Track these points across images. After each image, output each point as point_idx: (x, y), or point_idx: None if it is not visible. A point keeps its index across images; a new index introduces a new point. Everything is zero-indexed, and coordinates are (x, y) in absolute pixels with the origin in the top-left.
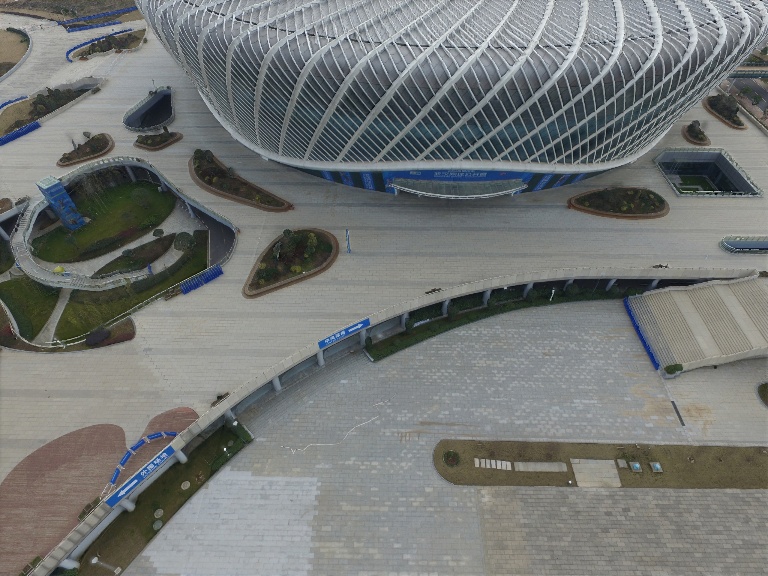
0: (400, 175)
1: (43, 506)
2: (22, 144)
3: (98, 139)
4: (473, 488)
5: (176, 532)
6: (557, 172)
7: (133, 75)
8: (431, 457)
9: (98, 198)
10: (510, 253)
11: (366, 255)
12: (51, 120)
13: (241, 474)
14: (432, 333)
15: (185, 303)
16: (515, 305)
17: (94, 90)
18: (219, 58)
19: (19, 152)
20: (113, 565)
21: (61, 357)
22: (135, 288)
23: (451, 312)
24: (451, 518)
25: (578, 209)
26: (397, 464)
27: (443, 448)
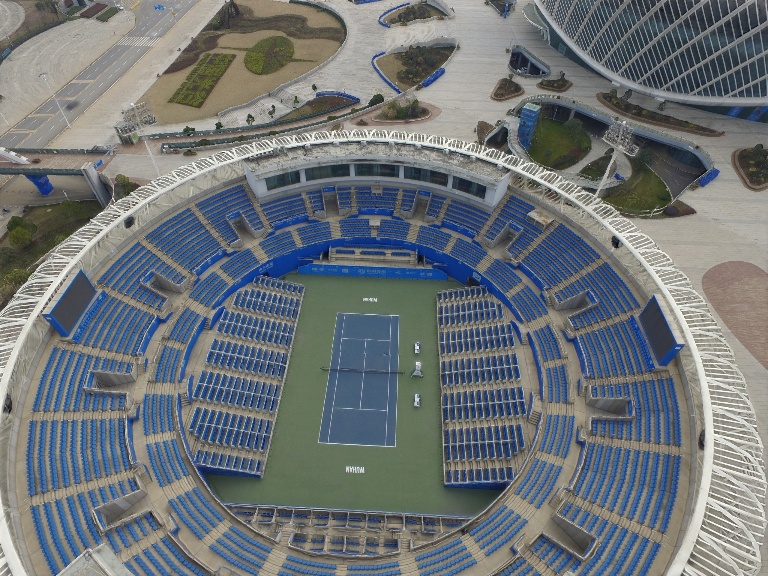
0: None
1: (749, 303)
2: (445, 84)
3: (511, 82)
4: None
5: None
6: None
7: (473, 37)
8: None
9: (541, 125)
10: None
11: None
12: (447, 68)
13: None
14: None
15: (710, 192)
16: None
17: (458, 47)
18: (729, 5)
19: (450, 90)
20: None
21: (655, 222)
22: (625, 189)
23: None
24: None
25: None
26: None
27: None
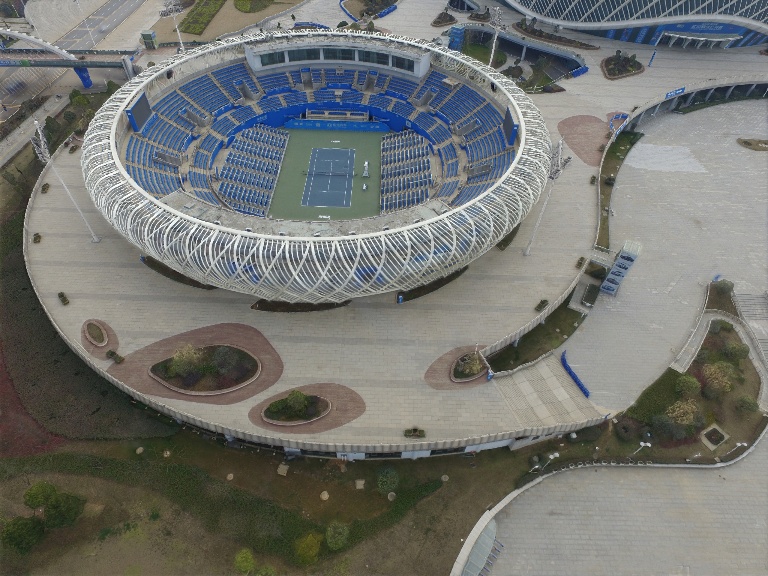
0: (669, 28)
1: None
2: (396, 16)
3: (447, 14)
4: (764, 152)
5: (633, 158)
6: (760, 29)
7: None
8: (737, 143)
9: (468, 44)
10: (740, 70)
11: (660, 68)
12: (399, 6)
13: (648, 144)
14: (707, 105)
15: (579, 80)
16: (745, 97)
17: None
18: None
19: (400, 20)
20: (613, 166)
21: (536, 95)
22: None
23: (717, 94)
24: (760, 159)
25: (767, 55)
26: (722, 144)
27: (741, 141)
